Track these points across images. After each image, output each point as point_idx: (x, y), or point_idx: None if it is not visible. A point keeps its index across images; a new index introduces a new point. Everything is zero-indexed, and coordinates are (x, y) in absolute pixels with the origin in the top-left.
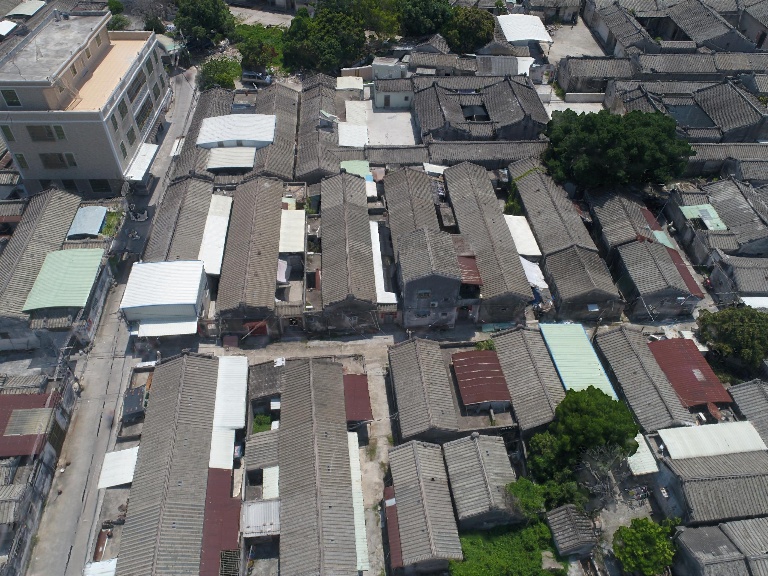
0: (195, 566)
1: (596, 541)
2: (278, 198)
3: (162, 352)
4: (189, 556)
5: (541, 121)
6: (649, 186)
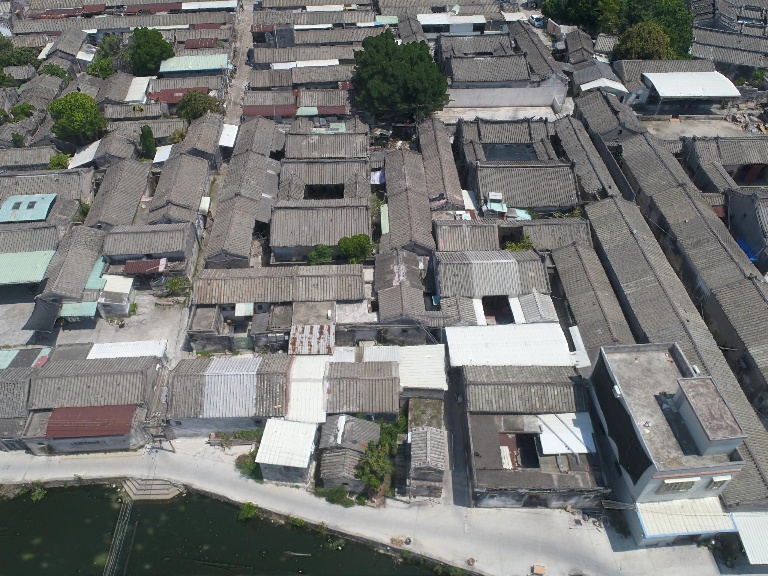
0: (145, 3)
1: (112, 65)
2: (353, 2)
3: (260, 6)
4: (148, 1)
5: (460, 71)
6: (404, 140)
